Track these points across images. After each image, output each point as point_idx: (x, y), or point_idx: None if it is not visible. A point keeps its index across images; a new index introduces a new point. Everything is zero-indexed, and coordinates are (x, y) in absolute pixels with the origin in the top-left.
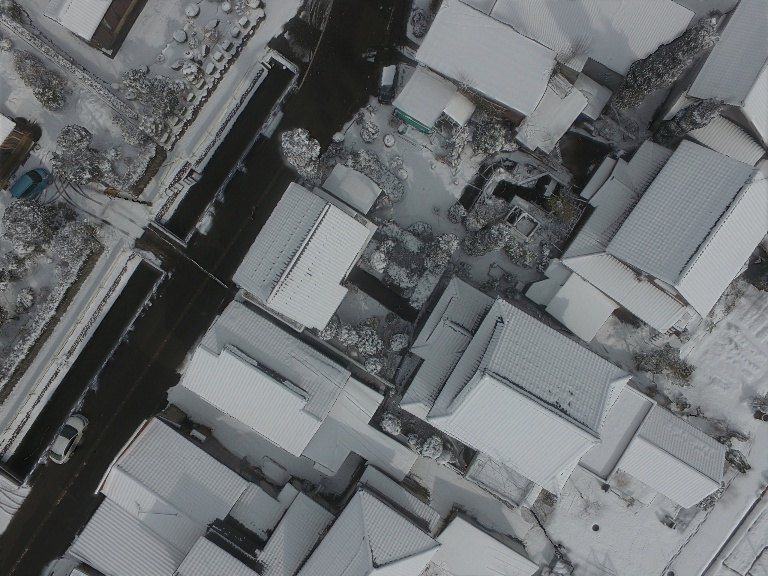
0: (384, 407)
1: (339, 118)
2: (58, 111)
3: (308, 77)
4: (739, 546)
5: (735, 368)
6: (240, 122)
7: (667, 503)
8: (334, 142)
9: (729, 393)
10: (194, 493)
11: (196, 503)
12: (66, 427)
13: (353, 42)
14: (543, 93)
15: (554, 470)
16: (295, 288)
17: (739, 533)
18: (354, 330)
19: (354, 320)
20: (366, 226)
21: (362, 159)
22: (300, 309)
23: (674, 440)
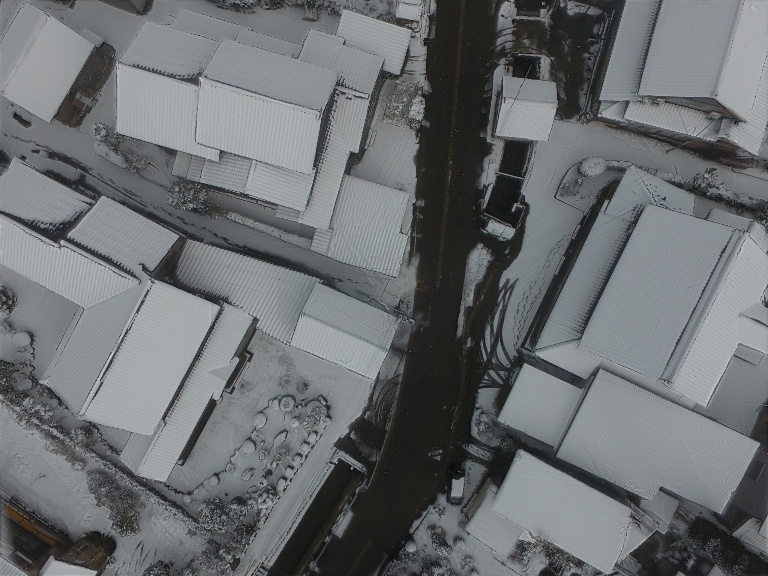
0: None
1: (408, 516)
2: None
3: (375, 476)
4: None
5: None
6: (308, 511)
7: None
8: None
9: None
10: None
11: None
12: None
13: (418, 440)
14: (620, 551)
15: None
16: None
17: None
18: None
19: None
20: None
21: (436, 575)
22: None
23: None
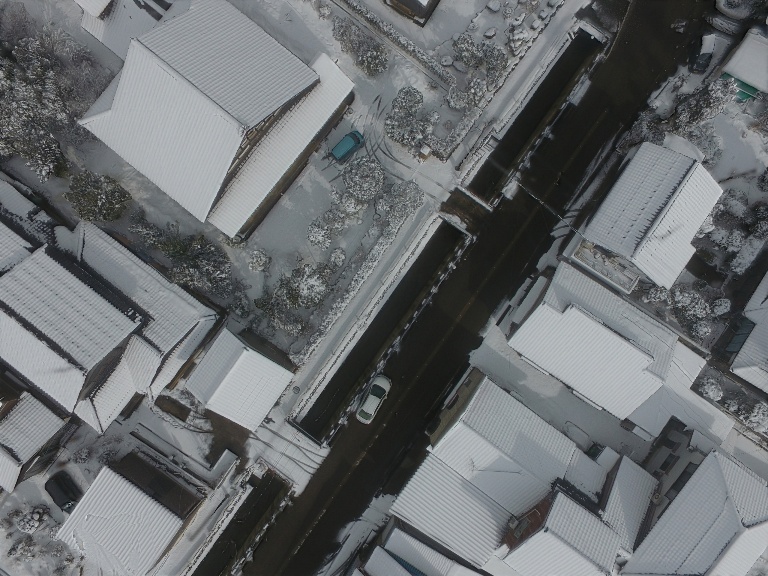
0: None
1: (647, 87)
2: (374, 76)
3: (615, 47)
4: None
5: None
6: (538, 91)
7: None
8: (649, 109)
9: None
10: (532, 451)
11: (536, 461)
12: (375, 387)
13: (661, 13)
14: None
15: None
16: (656, 245)
17: None
18: None
19: None
20: None
21: None
22: (656, 267)
23: None
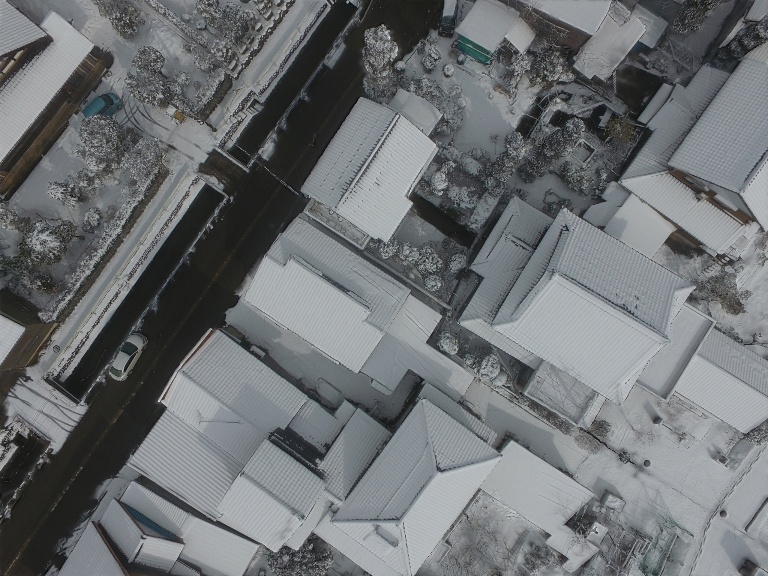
0: (440, 330)
1: (399, 50)
2: (131, 39)
3: (370, 11)
4: None
5: None
6: (302, 56)
7: (719, 439)
8: (395, 71)
9: None
10: (256, 402)
11: (258, 412)
12: (127, 344)
13: None
14: (606, 13)
15: (619, 377)
16: (363, 196)
17: None
18: (414, 248)
19: None
20: None
21: (424, 85)
22: (367, 218)
23: (733, 361)
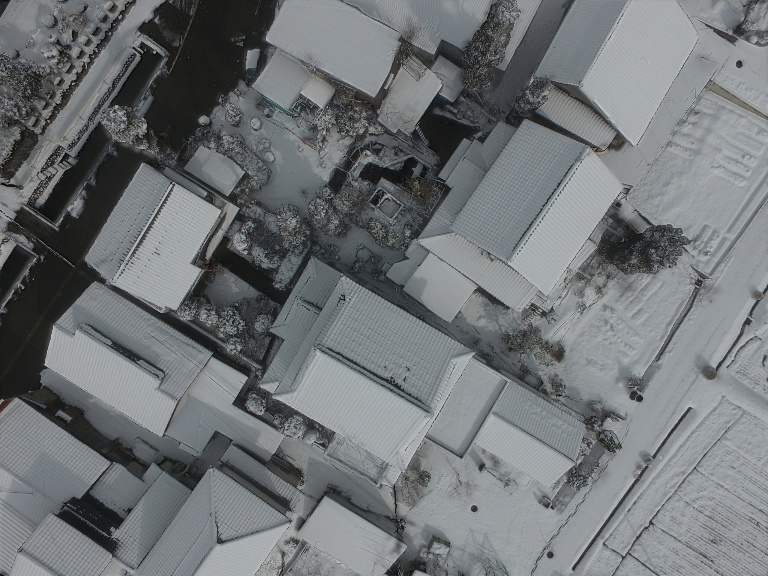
0: None
1: (209, 102)
2: None
3: (178, 61)
4: (619, 526)
5: (611, 349)
6: None
7: None
8: (201, 125)
9: (605, 374)
10: (51, 472)
11: (53, 482)
12: None
13: (223, 27)
14: (387, 74)
15: (396, 446)
16: (142, 267)
17: (618, 513)
18: (215, 311)
19: (225, 302)
20: (226, 207)
21: (225, 142)
22: (150, 288)
23: (531, 418)
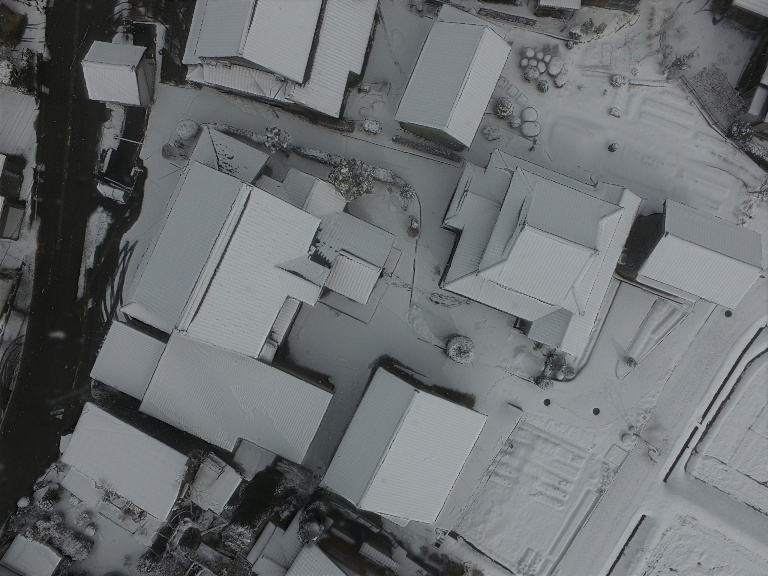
0: None
1: (31, 474)
2: None
3: (0, 435)
4: None
5: None
6: None
7: None
8: None
9: None
10: None
11: None
12: None
13: (42, 400)
14: (175, 499)
15: None
16: None
17: None
18: None
19: None
20: None
21: (41, 530)
22: None
23: None
